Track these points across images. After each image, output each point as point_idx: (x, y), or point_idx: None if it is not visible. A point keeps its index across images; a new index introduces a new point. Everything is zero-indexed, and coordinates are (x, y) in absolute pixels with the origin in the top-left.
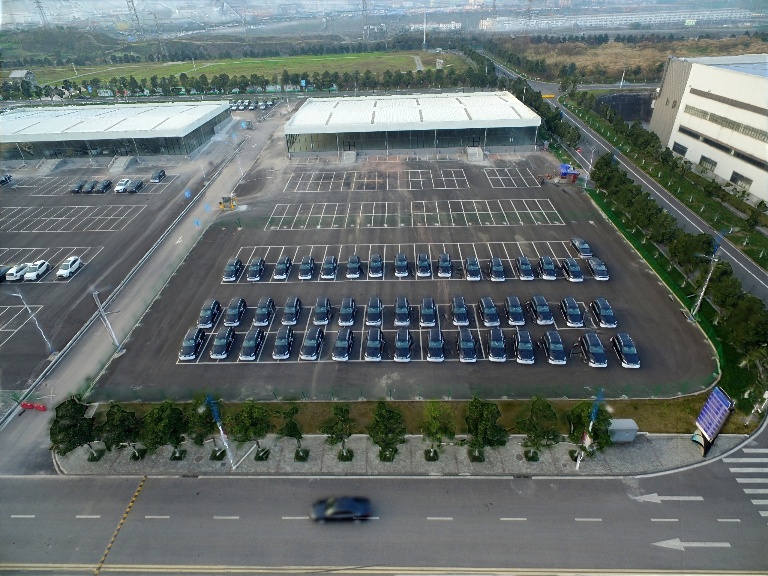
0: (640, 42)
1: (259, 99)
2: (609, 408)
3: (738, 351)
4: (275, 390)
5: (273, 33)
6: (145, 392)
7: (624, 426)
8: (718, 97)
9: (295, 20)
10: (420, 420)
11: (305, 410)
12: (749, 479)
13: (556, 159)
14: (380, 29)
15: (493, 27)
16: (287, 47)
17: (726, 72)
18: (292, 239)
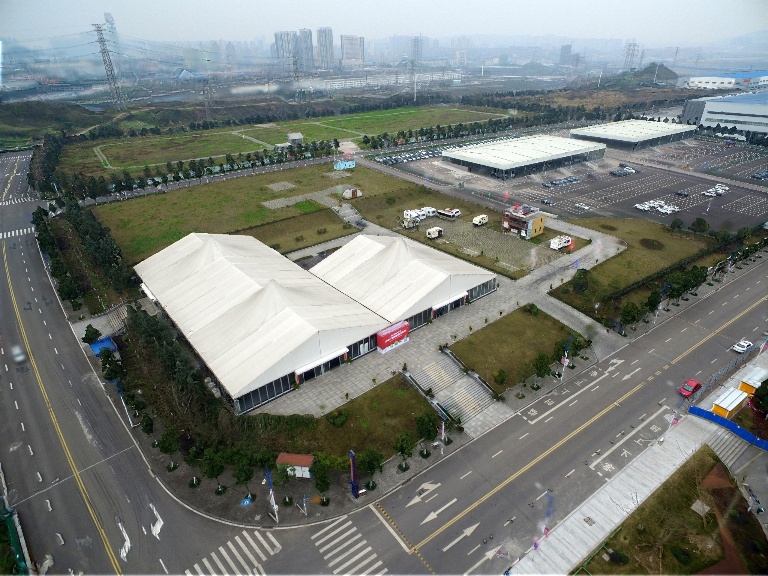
0: (536, 95)
1: (501, 136)
2: None
3: None
4: None
5: (217, 98)
6: None
7: None
8: (729, 113)
9: (240, 86)
10: None
11: None
12: None
13: (706, 141)
14: (309, 91)
15: (443, 88)
16: (260, 109)
17: (732, 104)
18: None
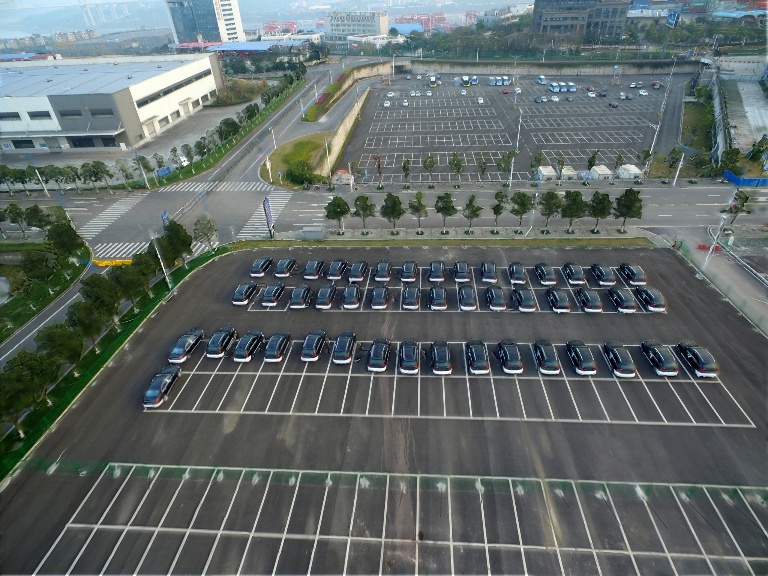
0: None
1: None
2: (306, 245)
3: (171, 278)
4: (531, 252)
5: None
6: (632, 252)
7: (311, 227)
8: None
9: None
10: (425, 242)
11: (502, 244)
12: (264, 229)
13: None
14: None
15: None
16: None
17: None
18: (669, 446)
